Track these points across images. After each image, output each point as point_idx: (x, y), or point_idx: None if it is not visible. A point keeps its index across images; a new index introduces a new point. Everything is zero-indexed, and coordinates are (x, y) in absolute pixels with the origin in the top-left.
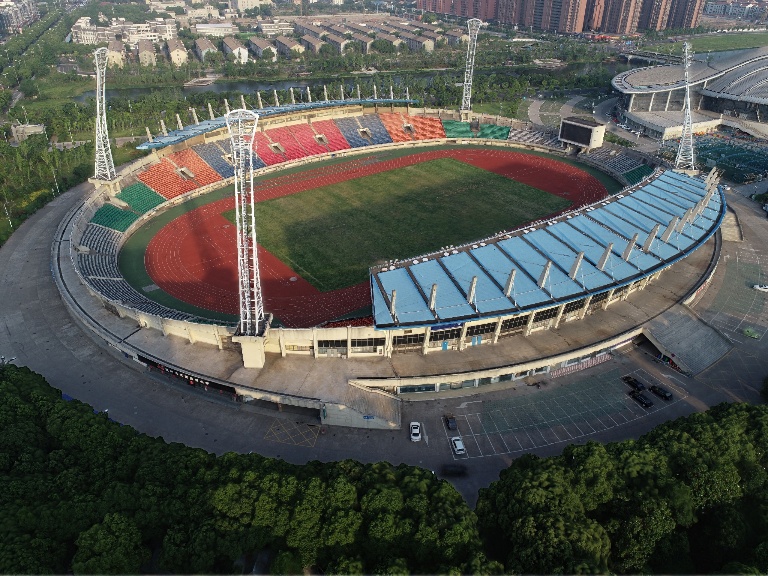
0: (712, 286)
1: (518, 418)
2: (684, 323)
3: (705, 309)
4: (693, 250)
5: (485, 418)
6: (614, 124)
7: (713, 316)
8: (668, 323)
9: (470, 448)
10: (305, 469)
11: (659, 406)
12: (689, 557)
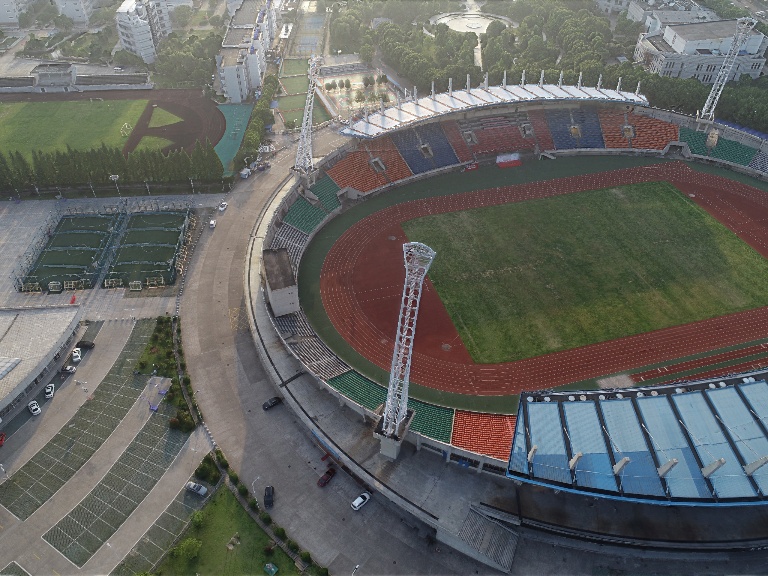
0: None
1: None
2: None
3: None
4: None
5: None
6: (31, 424)
7: None
8: None
9: None
10: (667, 84)
11: None
12: None
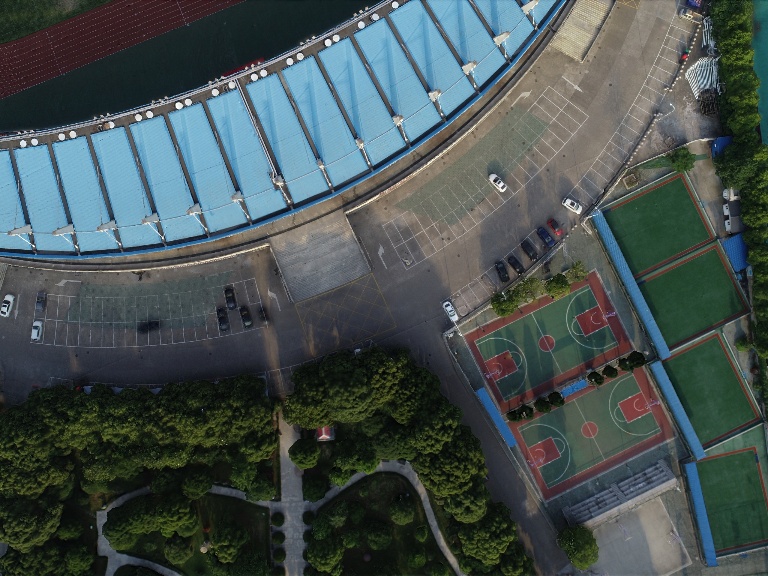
0: (445, 158)
1: (103, 311)
2: (329, 239)
3: (397, 201)
4: (349, 187)
5: (75, 304)
6: None
7: (395, 216)
8: (307, 239)
9: (48, 334)
10: None
11: (235, 330)
12: (141, 476)
